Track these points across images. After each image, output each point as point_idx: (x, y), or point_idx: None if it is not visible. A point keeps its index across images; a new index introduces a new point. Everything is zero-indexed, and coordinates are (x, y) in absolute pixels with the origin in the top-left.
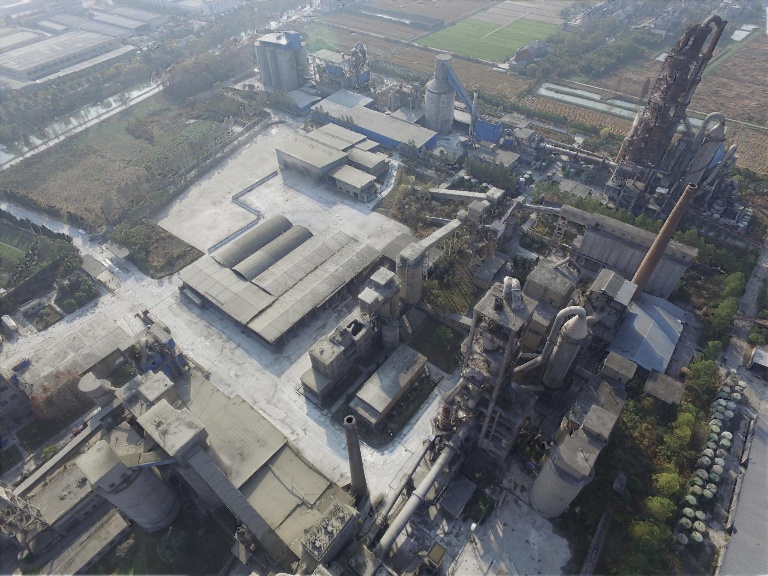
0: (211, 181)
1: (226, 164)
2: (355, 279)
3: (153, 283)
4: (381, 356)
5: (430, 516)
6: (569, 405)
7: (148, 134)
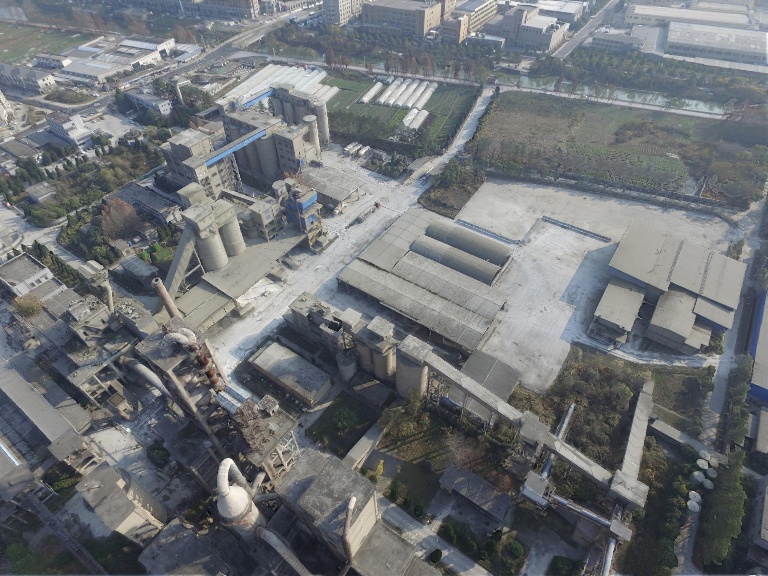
0: (567, 197)
1: (604, 199)
2: (433, 333)
3: (413, 200)
4: (332, 368)
5: (167, 413)
6: (241, 569)
7: (625, 137)
